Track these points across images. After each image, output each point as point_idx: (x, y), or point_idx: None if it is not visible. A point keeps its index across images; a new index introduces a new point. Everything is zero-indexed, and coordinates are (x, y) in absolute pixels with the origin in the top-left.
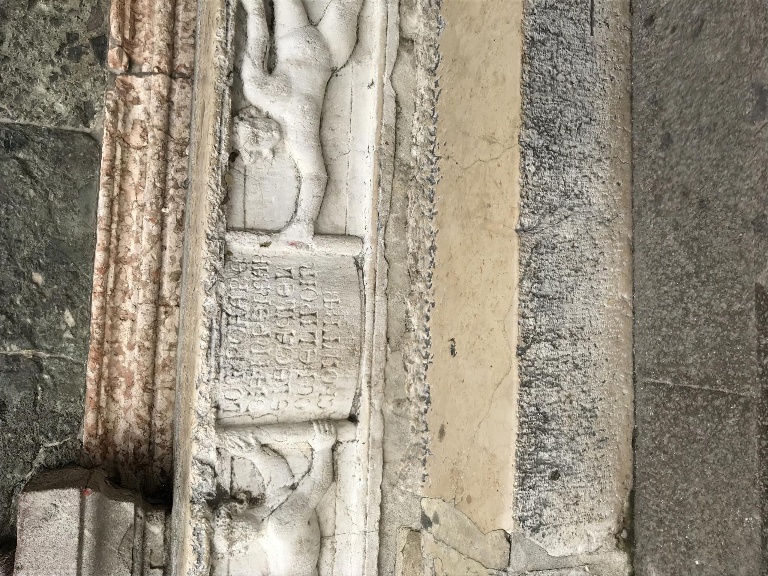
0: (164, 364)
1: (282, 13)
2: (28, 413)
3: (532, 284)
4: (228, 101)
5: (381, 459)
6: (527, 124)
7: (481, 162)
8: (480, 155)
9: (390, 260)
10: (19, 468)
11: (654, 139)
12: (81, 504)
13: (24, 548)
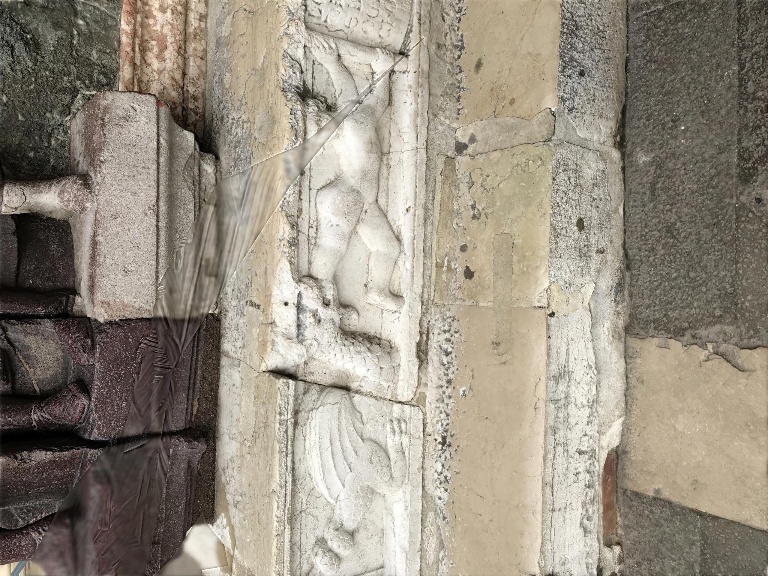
0: (195, 33)
1: None
2: (65, 55)
3: None
4: None
5: (428, 89)
6: None
7: None
8: None
9: None
10: (58, 109)
11: None
12: (157, 112)
13: (107, 142)
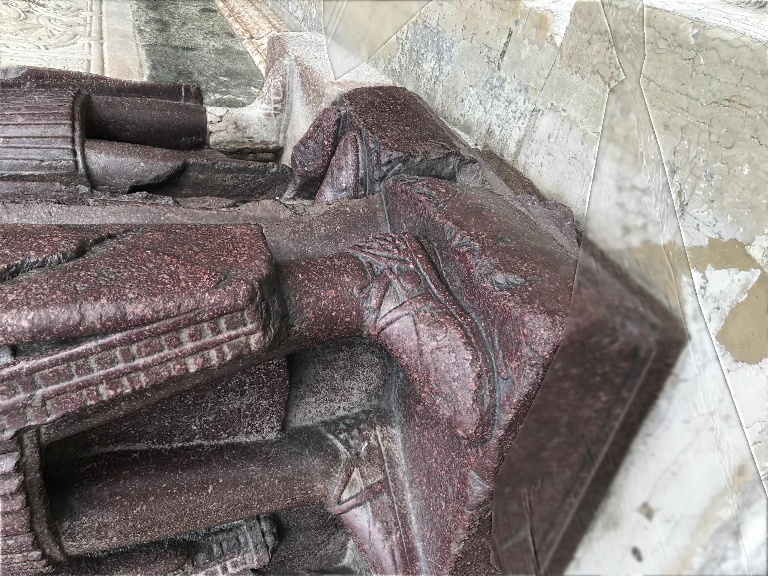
0: None
1: None
2: None
3: None
4: None
5: None
6: None
7: None
8: None
9: None
10: None
11: None
12: None
13: None
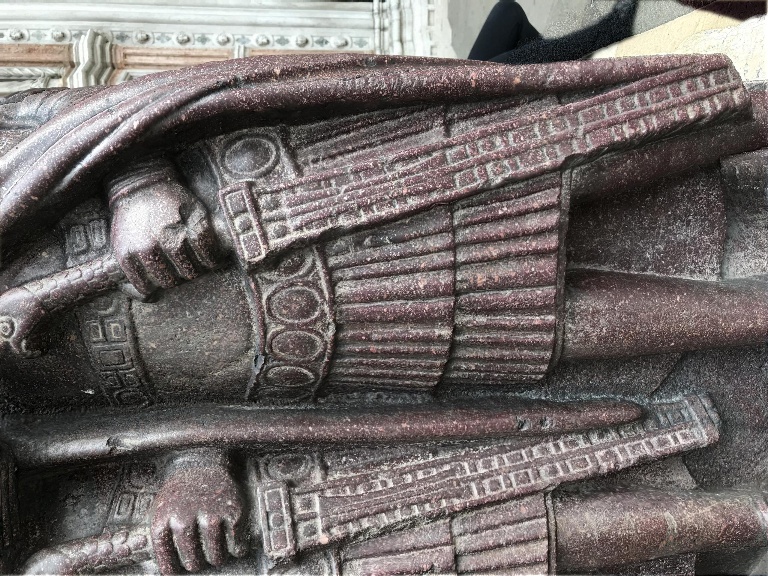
0: None
1: None
2: None
3: None
4: None
5: None
6: None
7: None
8: None
9: None
10: None
11: None
12: None
13: None
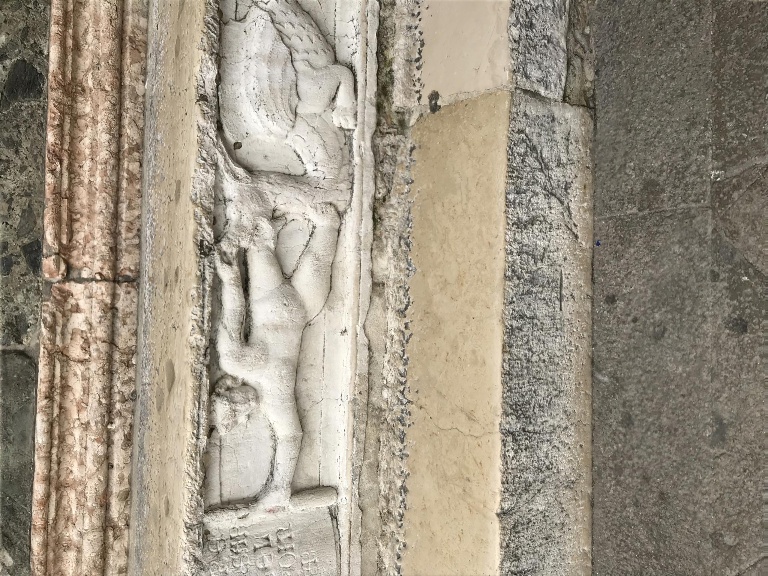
0: None
1: (258, 276)
2: None
3: (511, 563)
4: (206, 382)
5: None
6: (507, 411)
7: (459, 432)
8: (458, 425)
9: (363, 507)
10: None
11: (615, 411)
12: None
13: None
